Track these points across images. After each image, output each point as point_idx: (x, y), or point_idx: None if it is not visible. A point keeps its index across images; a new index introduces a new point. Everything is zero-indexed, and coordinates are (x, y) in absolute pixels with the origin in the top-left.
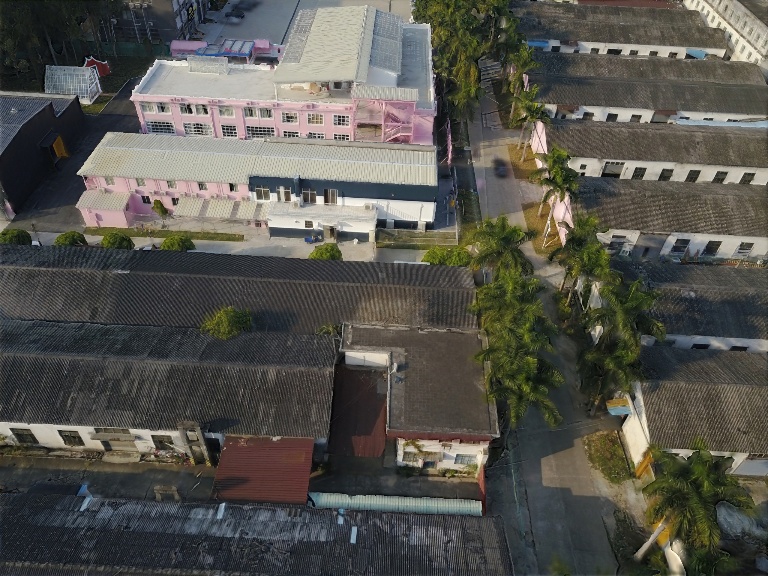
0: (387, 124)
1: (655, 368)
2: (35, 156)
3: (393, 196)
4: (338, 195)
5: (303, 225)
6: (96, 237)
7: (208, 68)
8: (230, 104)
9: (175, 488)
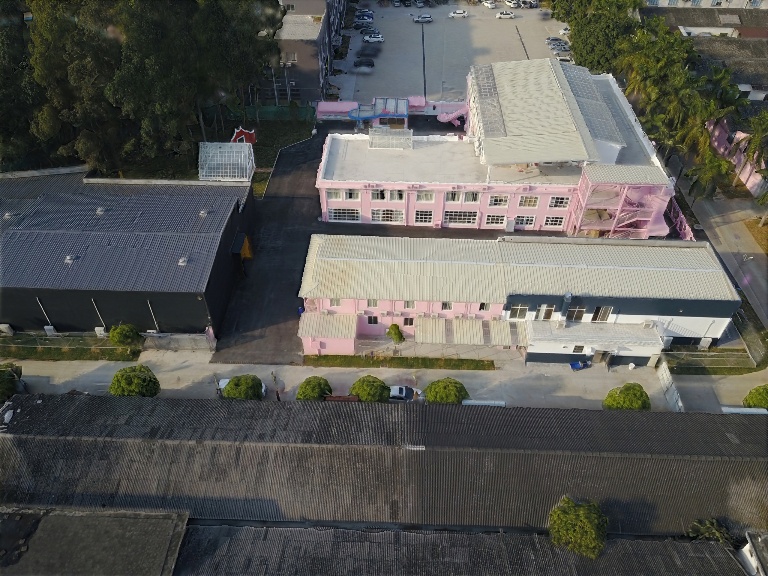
0: (624, 209)
1: None
2: (228, 265)
3: (680, 312)
4: (612, 312)
5: (571, 350)
6: (320, 369)
7: (391, 143)
8: (432, 189)
9: None
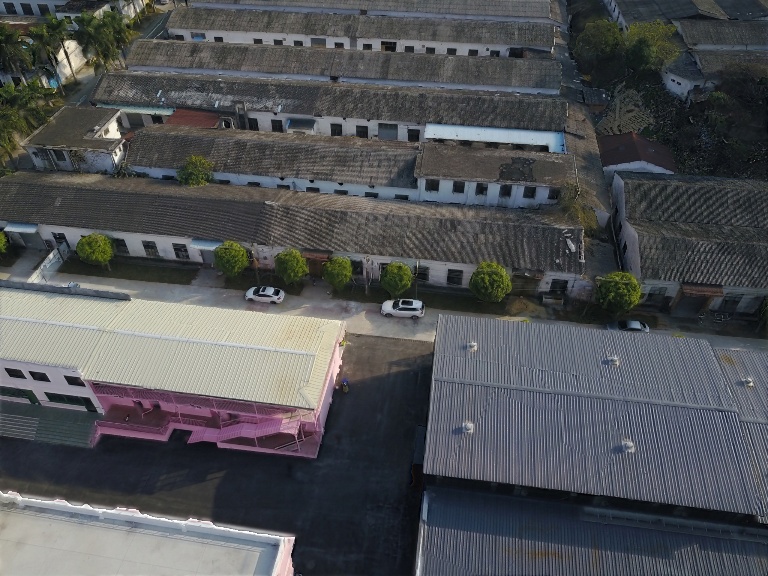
0: None
1: None
2: None
3: None
4: None
5: None
6: None
7: None
8: None
9: (234, 100)
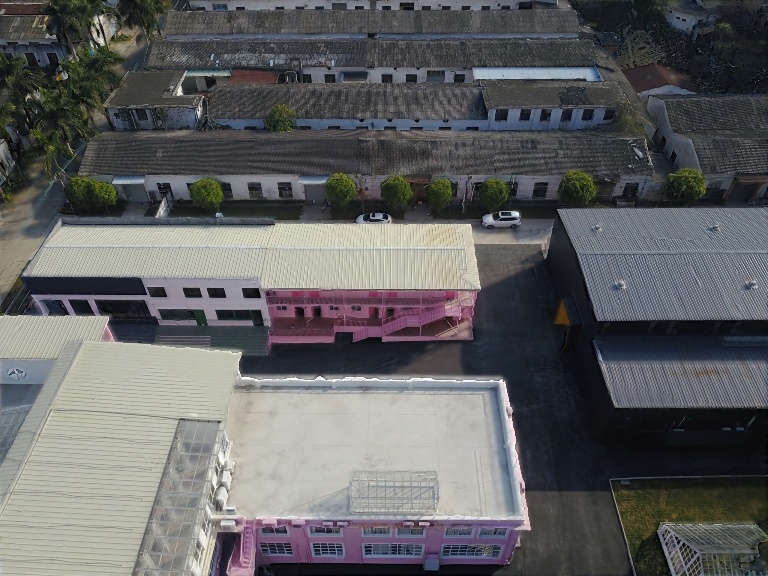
0: None
1: (5, 103)
2: None
3: None
4: None
5: None
6: None
7: None
8: None
9: (291, 57)
